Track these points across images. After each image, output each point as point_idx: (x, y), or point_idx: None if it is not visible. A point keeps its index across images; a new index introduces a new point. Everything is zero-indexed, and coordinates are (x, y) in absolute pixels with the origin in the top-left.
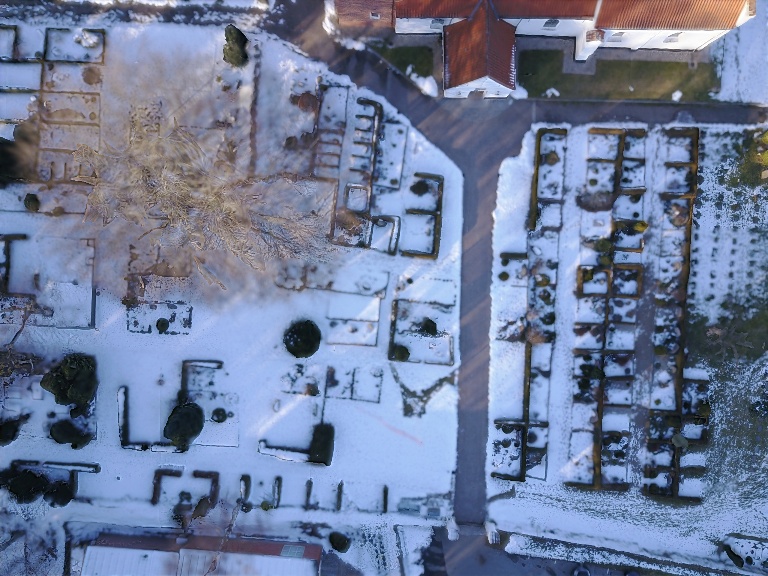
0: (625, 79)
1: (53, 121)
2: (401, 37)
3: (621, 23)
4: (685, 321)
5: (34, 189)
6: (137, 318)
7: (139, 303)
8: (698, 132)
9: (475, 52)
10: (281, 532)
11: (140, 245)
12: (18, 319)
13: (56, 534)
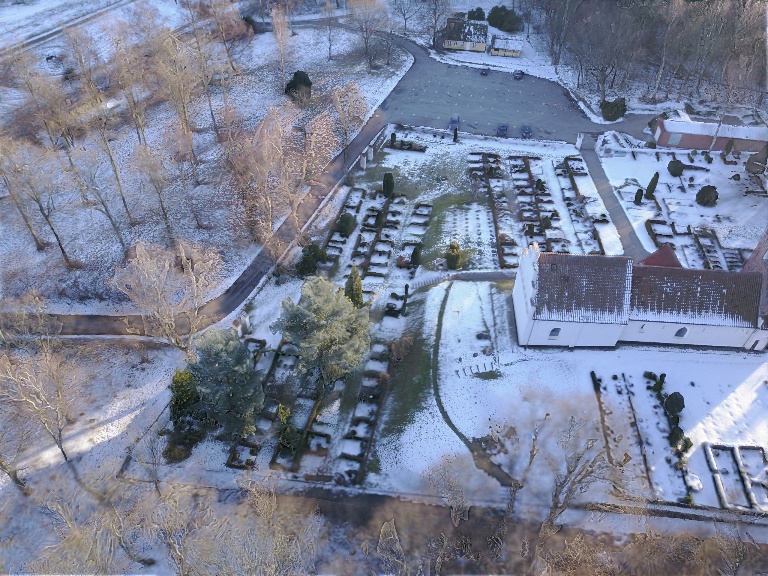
0: None
1: None
2: None
3: None
4: None
5: None
6: None
7: None
8: (503, 264)
9: None
10: None
11: None
12: None
13: None
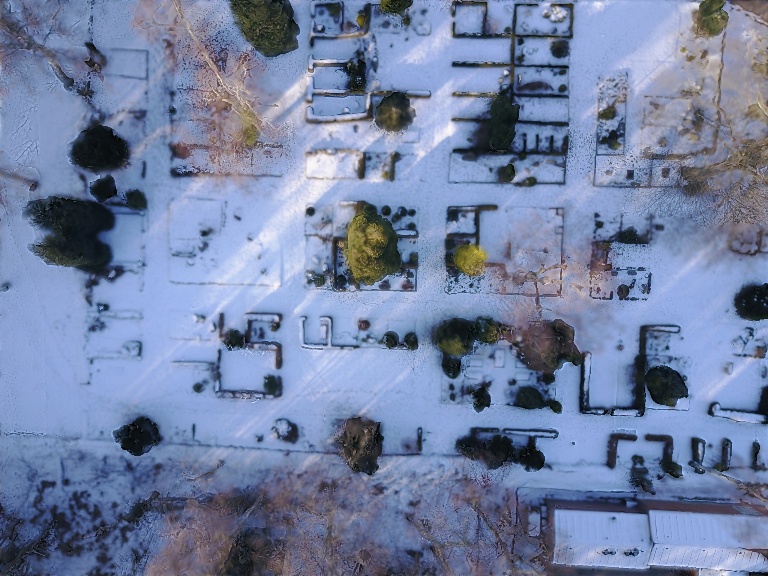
0: None
1: (524, 94)
2: None
3: None
4: None
5: (506, 161)
6: (599, 285)
7: (601, 270)
8: None
9: None
10: (724, 494)
11: (604, 213)
12: (485, 288)
13: (509, 500)
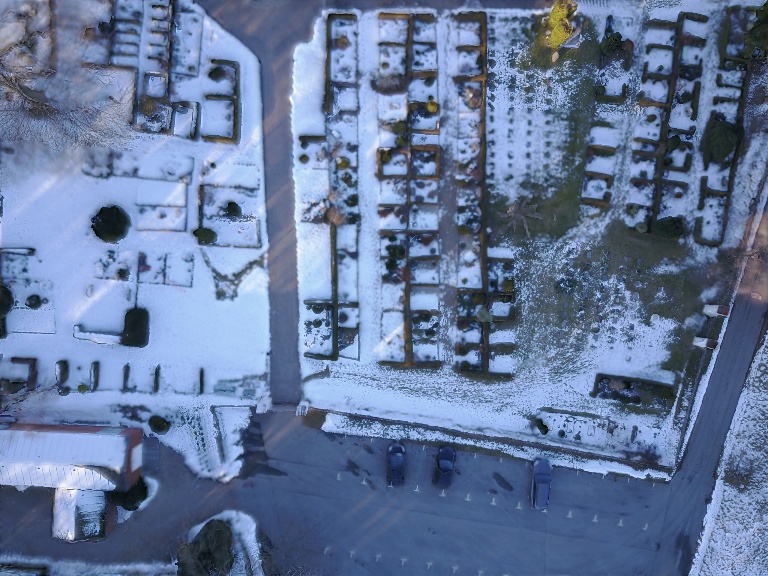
0: None
1: None
2: None
3: None
4: (486, 201)
5: None
6: None
7: None
8: (484, 16)
9: None
10: (102, 417)
11: None
12: None
13: None
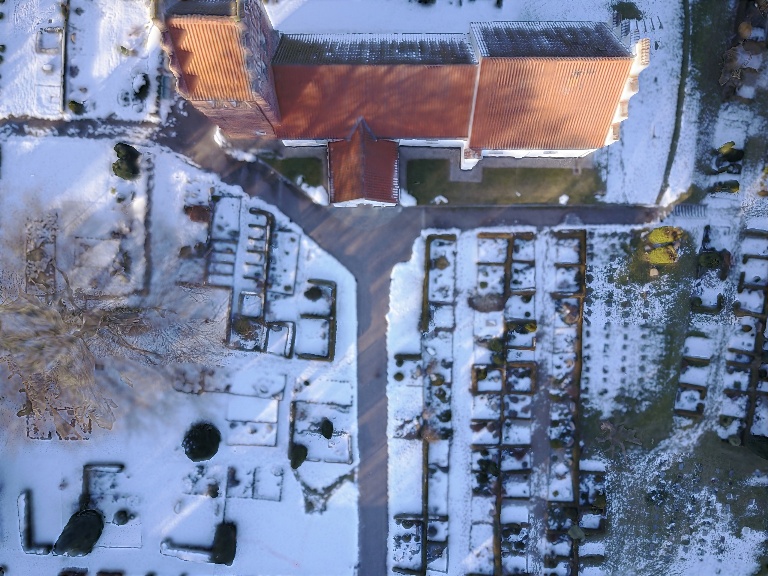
0: (511, 185)
1: None
2: (291, 149)
3: (494, 144)
4: (579, 415)
5: None
6: (37, 425)
7: None
8: (585, 234)
9: (354, 173)
10: None
11: None
12: None
13: None
